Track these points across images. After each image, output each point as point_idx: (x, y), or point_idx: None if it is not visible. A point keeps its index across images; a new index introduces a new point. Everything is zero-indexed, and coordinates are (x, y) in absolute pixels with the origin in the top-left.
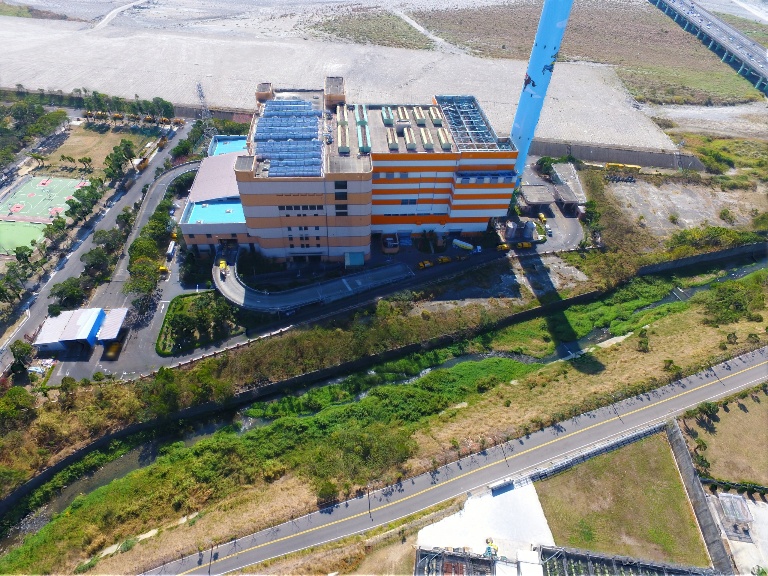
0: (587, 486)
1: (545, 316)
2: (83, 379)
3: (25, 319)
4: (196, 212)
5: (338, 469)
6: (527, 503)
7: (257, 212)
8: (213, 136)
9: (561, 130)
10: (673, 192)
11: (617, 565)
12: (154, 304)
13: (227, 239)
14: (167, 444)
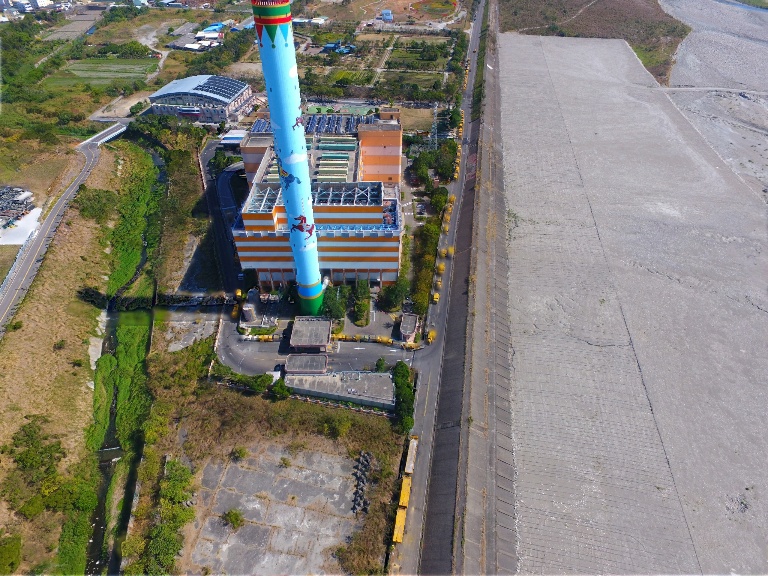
0: (1, 262)
1: (150, 311)
2: None
3: None
4: None
5: None
6: (18, 240)
7: None
8: None
9: (554, 455)
10: None
11: None
12: None
13: None
14: None
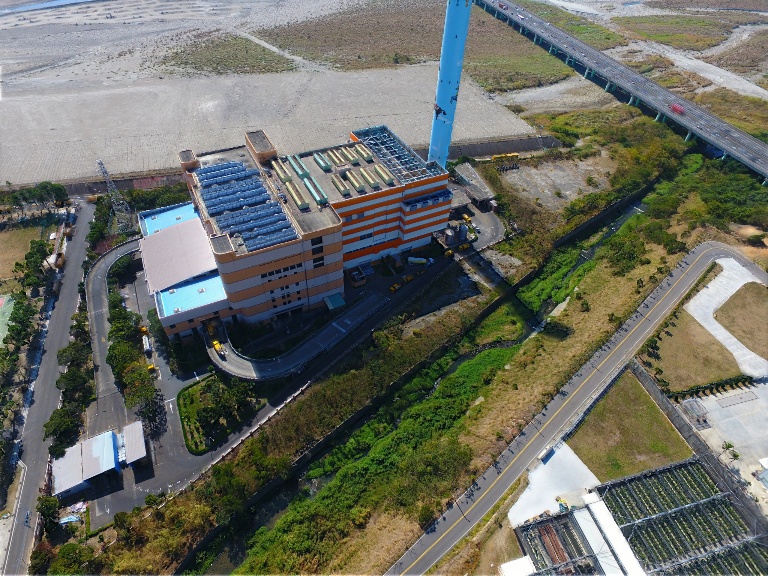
0: (600, 430)
1: (505, 303)
2: (135, 509)
3: (23, 472)
4: (167, 301)
5: (418, 492)
6: (569, 459)
7: (241, 286)
8: (137, 214)
9: None
10: (549, 170)
11: (644, 478)
12: (160, 406)
13: (209, 318)
14: (250, 535)
